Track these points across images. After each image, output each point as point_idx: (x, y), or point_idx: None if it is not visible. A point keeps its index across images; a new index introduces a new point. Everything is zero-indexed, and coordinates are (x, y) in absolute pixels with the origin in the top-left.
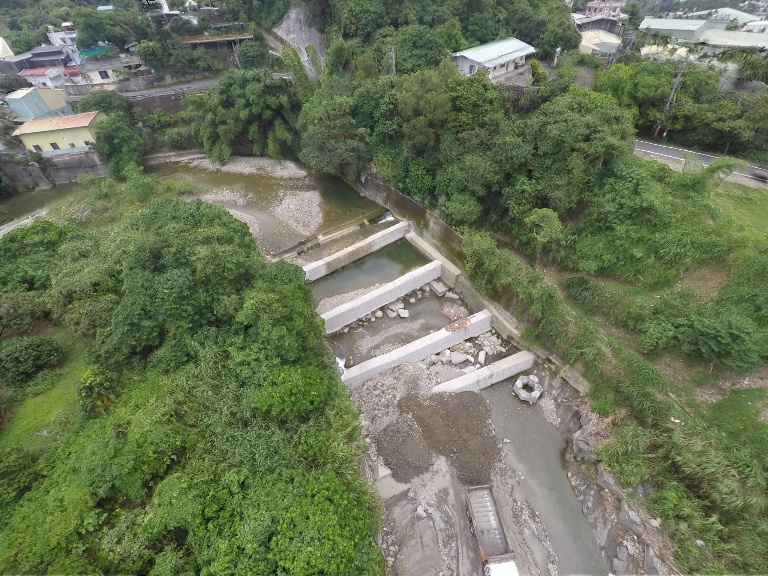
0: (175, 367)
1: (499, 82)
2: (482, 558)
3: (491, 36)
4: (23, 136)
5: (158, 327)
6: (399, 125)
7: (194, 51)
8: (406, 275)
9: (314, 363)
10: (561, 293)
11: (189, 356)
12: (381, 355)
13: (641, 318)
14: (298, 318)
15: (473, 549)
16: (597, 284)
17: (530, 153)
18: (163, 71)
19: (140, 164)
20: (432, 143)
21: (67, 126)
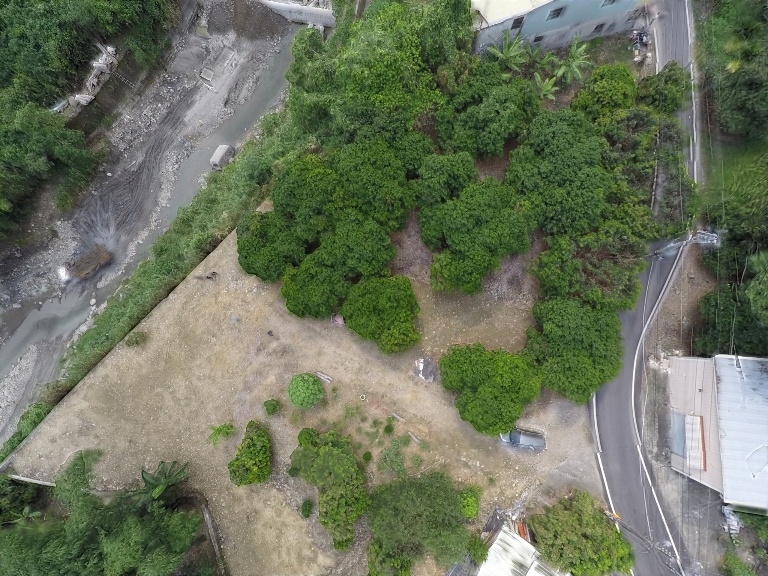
0: None
1: None
2: None
3: None
4: None
5: None
6: None
7: None
8: None
9: None
10: None
11: None
12: None
13: None
14: None
15: None
16: None
17: None
18: None
19: None
20: None
21: None
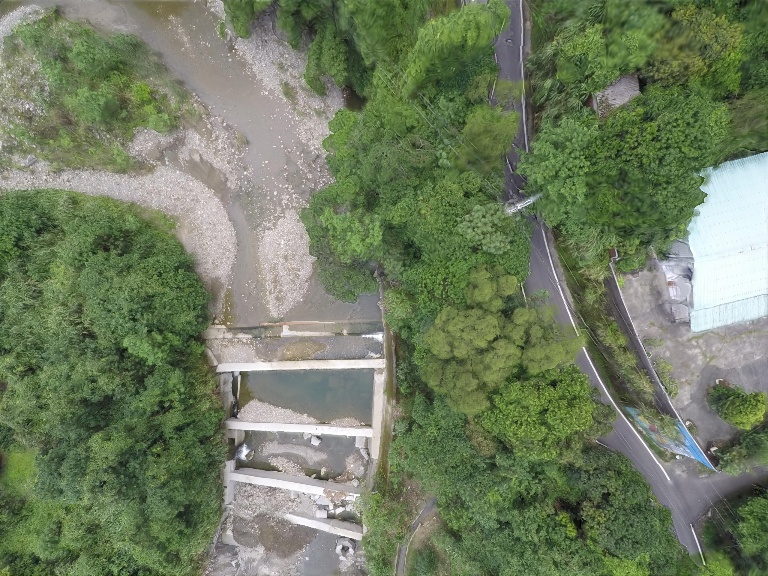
0: None
1: None
2: None
3: None
4: None
5: None
6: None
7: None
8: (332, 428)
9: None
10: (419, 545)
11: None
12: (266, 478)
13: None
14: None
15: None
16: None
17: None
18: None
19: None
20: None
21: None
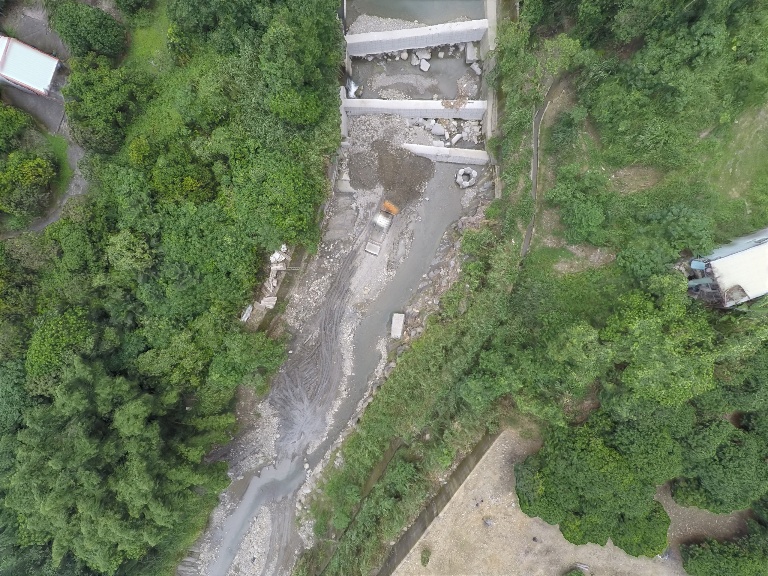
0: (225, 50)
1: None
2: None
3: None
4: None
5: (212, 13)
6: None
7: None
8: (446, 25)
9: (316, 92)
10: (551, 121)
11: (234, 45)
12: (381, 99)
13: (567, 177)
14: (308, 55)
15: None
16: (574, 132)
17: None
18: None
19: None
20: None
21: None
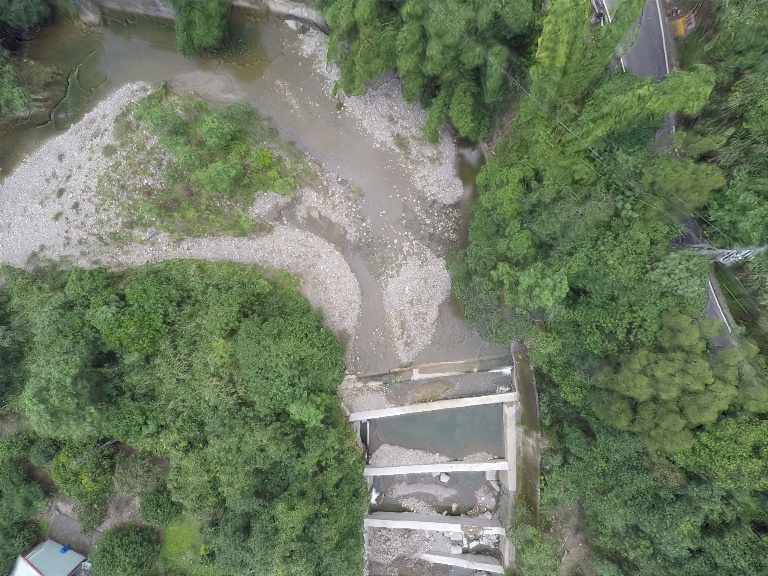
0: None
1: None
2: None
3: None
4: None
5: None
6: None
7: None
8: (467, 465)
9: None
10: (567, 573)
11: None
12: (402, 521)
13: None
14: None
15: None
16: None
17: (679, 554)
18: None
19: None
20: None
21: None
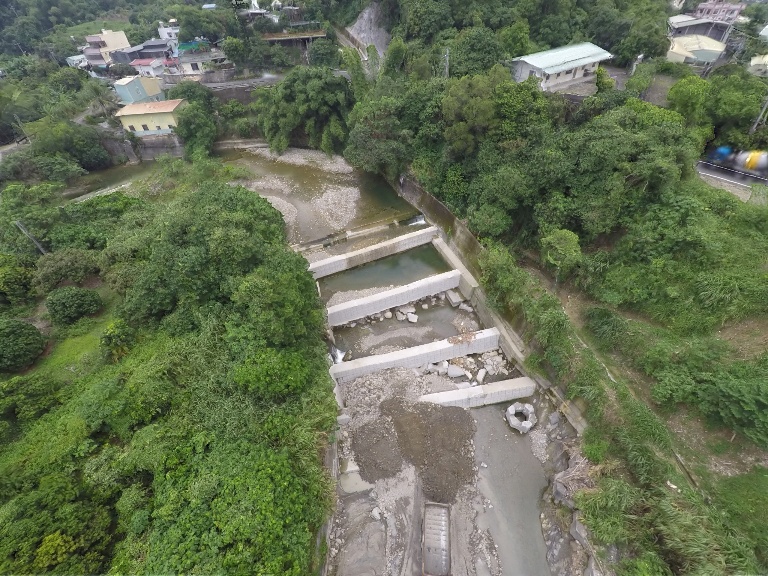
0: (180, 332)
1: (560, 90)
2: (422, 574)
3: (565, 40)
4: (122, 117)
5: (171, 295)
6: (442, 129)
7: (271, 48)
8: (422, 280)
9: (300, 350)
10: (580, 323)
11: (194, 325)
12: (377, 355)
13: (660, 364)
14: (289, 306)
15: (418, 563)
16: (619, 319)
17: (569, 169)
18: (243, 65)
19: (210, 148)
20: (470, 150)
21: (156, 111)
